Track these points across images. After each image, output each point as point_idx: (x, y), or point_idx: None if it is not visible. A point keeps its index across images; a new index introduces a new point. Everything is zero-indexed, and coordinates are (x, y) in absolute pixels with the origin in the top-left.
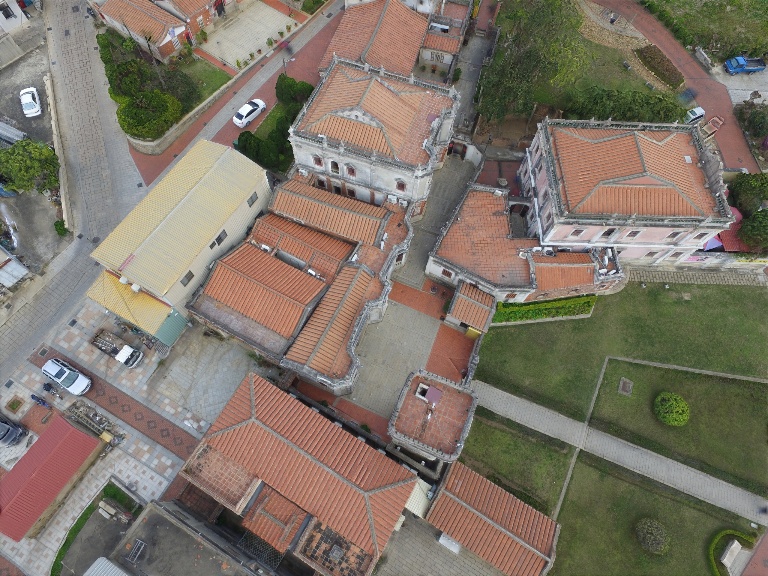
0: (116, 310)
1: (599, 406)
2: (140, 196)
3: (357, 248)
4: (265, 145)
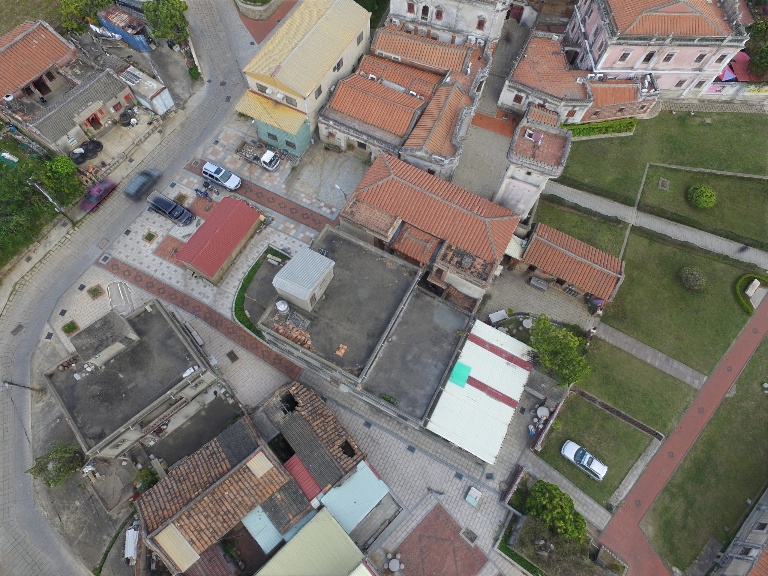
0: (262, 119)
1: (644, 197)
2: (254, 51)
3: (449, 73)
4: (363, 1)
